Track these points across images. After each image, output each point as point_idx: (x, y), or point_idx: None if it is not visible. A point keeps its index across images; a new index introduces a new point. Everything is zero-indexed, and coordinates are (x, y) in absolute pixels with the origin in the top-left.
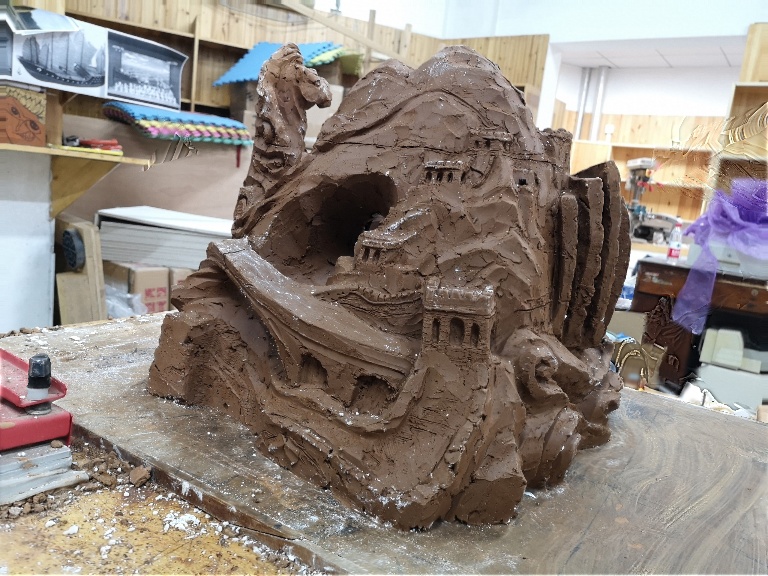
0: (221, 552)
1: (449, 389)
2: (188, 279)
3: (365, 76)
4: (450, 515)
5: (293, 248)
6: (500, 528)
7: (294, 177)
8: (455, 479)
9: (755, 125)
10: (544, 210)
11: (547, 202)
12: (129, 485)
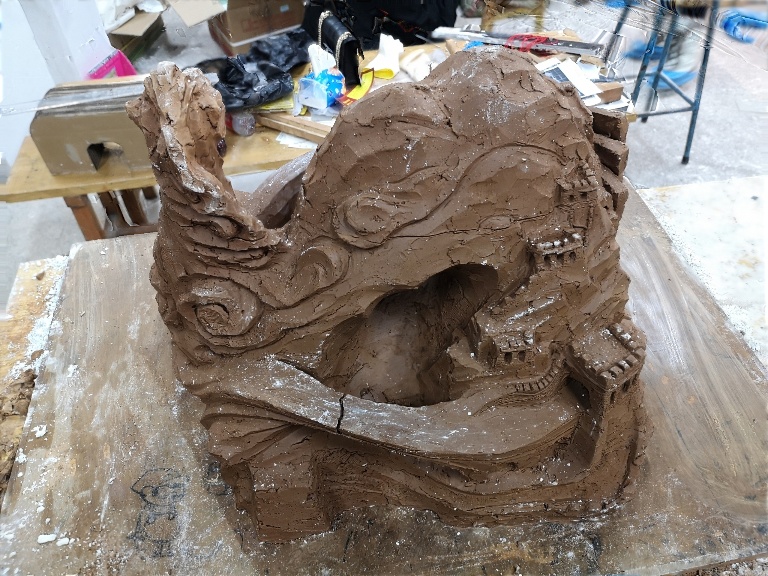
0: None
1: (622, 422)
2: (239, 439)
3: (371, 124)
4: None
5: (342, 340)
6: None
7: (332, 287)
8: None
9: (706, 17)
10: None
11: None
12: None
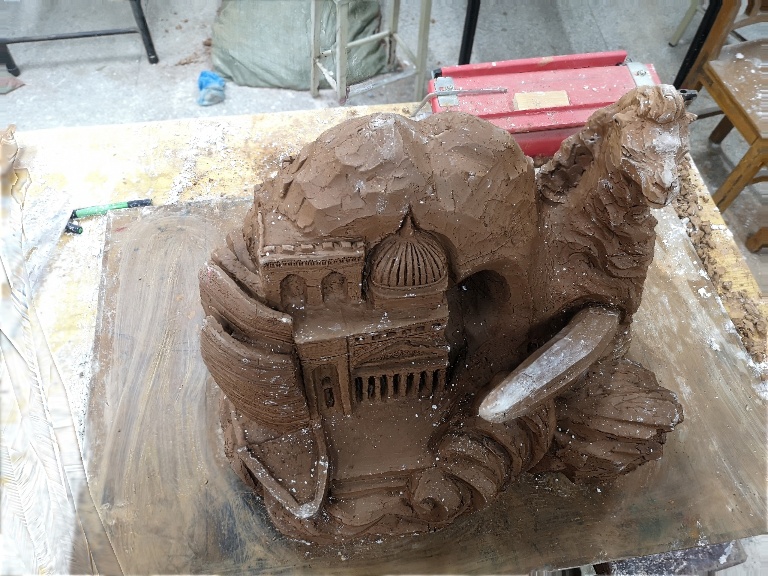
0: None
1: None
2: None
3: None
4: None
5: None
6: None
7: None
8: None
9: None
10: None
11: None
12: None
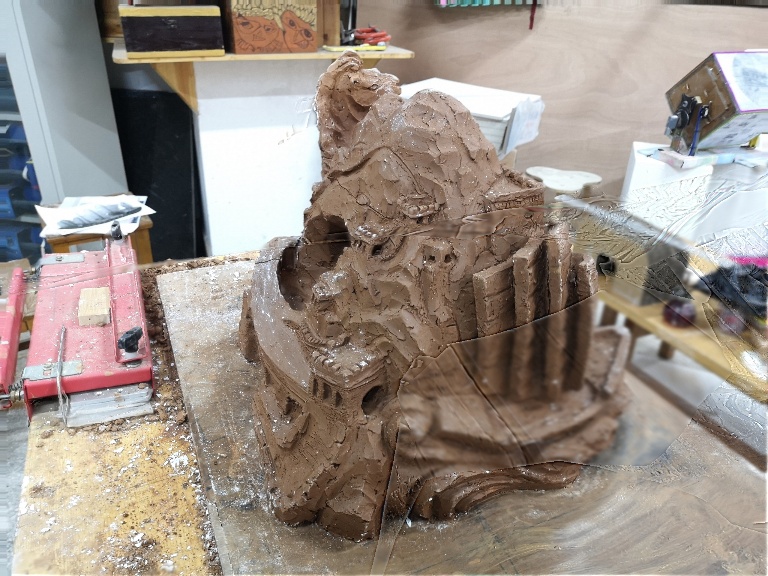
0: (178, 492)
1: (319, 435)
2: None
3: None
4: (319, 520)
5: (323, 254)
6: (348, 544)
7: (317, 198)
8: (308, 502)
9: None
10: (458, 284)
11: (461, 277)
12: (175, 422)
